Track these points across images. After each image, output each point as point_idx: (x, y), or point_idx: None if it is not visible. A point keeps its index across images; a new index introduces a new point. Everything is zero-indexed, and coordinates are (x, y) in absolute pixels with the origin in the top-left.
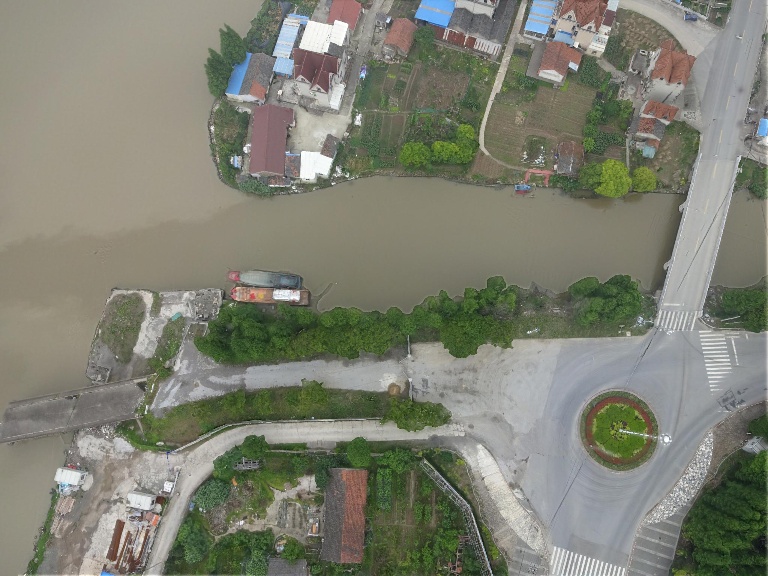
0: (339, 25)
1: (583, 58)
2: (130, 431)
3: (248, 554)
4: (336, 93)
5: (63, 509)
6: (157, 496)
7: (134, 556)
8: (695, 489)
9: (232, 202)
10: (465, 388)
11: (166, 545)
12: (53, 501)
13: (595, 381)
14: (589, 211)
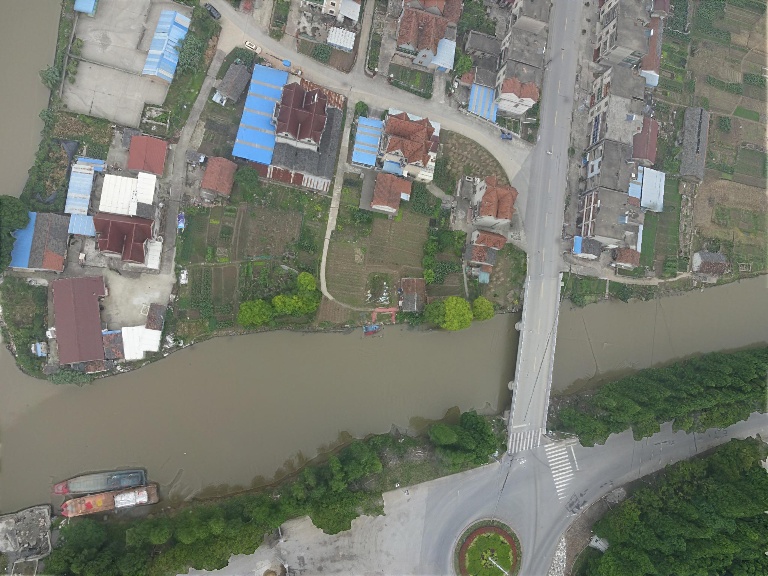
0: (145, 178)
1: (413, 184)
2: None
3: None
4: (153, 253)
5: None
6: None
7: None
8: None
9: (42, 396)
10: (342, 555)
11: None
12: None
13: (462, 516)
14: (435, 334)
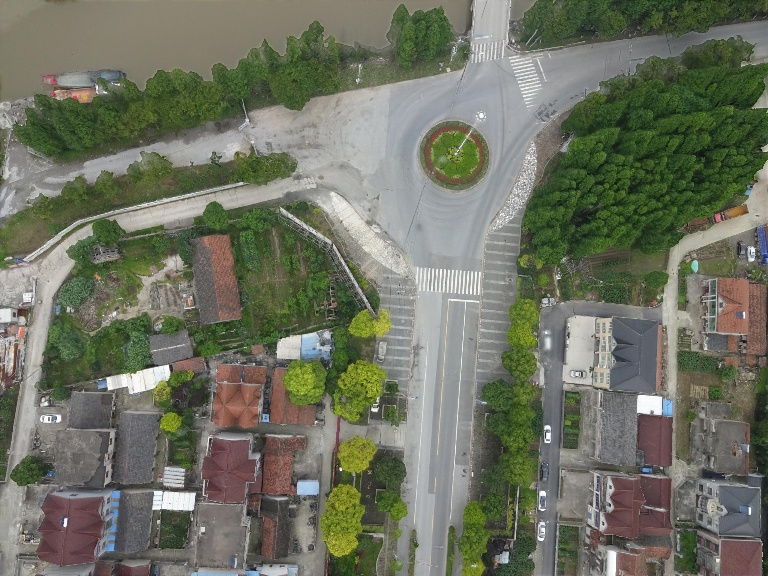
0: None
1: None
2: None
3: (127, 340)
4: None
5: None
6: (18, 309)
7: (7, 372)
8: (527, 193)
9: (30, 8)
10: (308, 144)
11: (39, 353)
12: None
13: (426, 116)
14: None
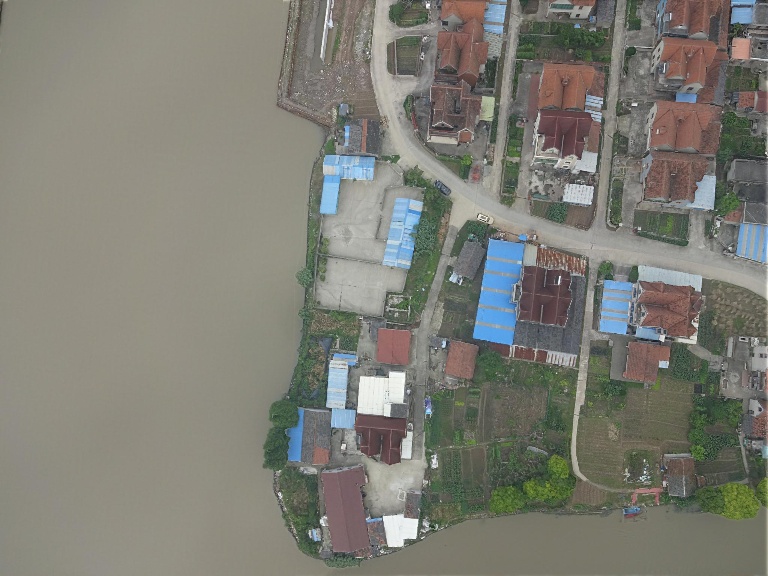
0: (395, 377)
1: (671, 347)
2: None
3: None
4: (406, 444)
5: None
6: None
7: None
8: None
9: (320, 574)
10: None
11: None
12: None
13: None
14: None
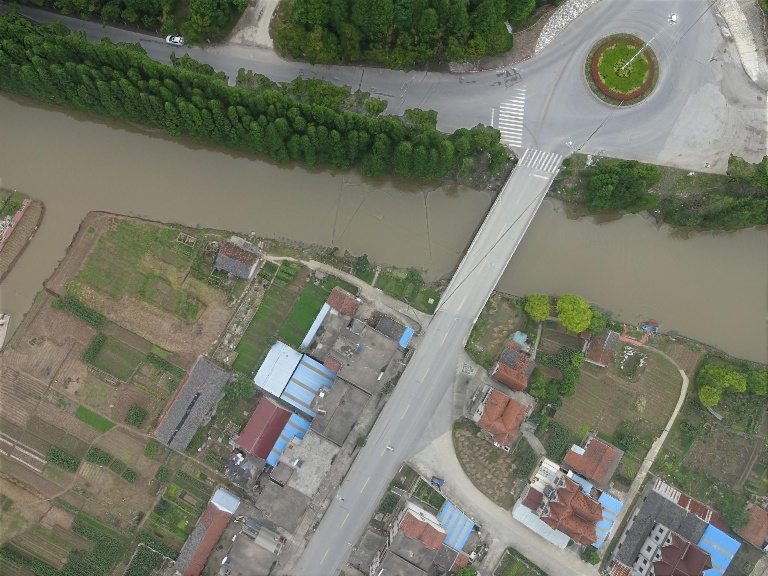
0: None
1: (560, 460)
2: None
3: None
4: None
5: None
6: None
7: None
8: (564, 7)
9: None
10: (759, 135)
11: None
12: None
13: (633, 119)
14: None
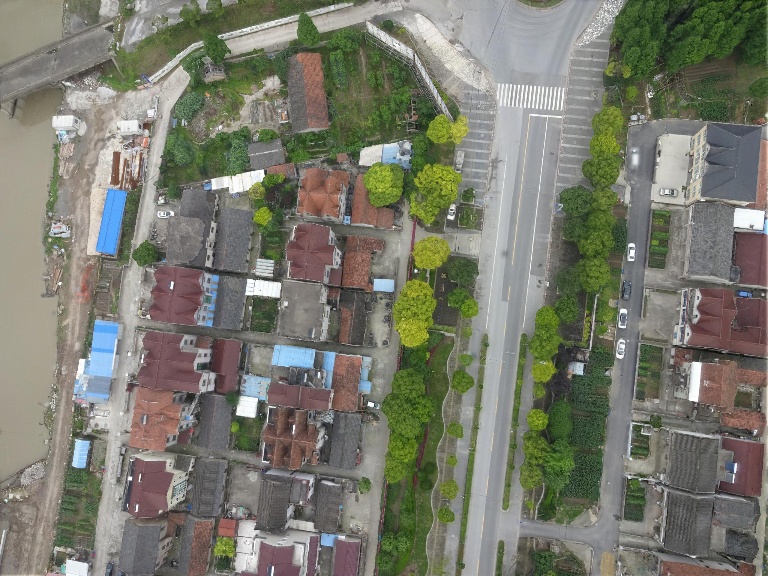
0: None
1: None
2: (109, 78)
3: None
4: None
5: (66, 154)
6: (143, 124)
7: (134, 177)
8: (618, 8)
9: None
10: None
11: (159, 160)
12: (56, 150)
13: None
14: None
